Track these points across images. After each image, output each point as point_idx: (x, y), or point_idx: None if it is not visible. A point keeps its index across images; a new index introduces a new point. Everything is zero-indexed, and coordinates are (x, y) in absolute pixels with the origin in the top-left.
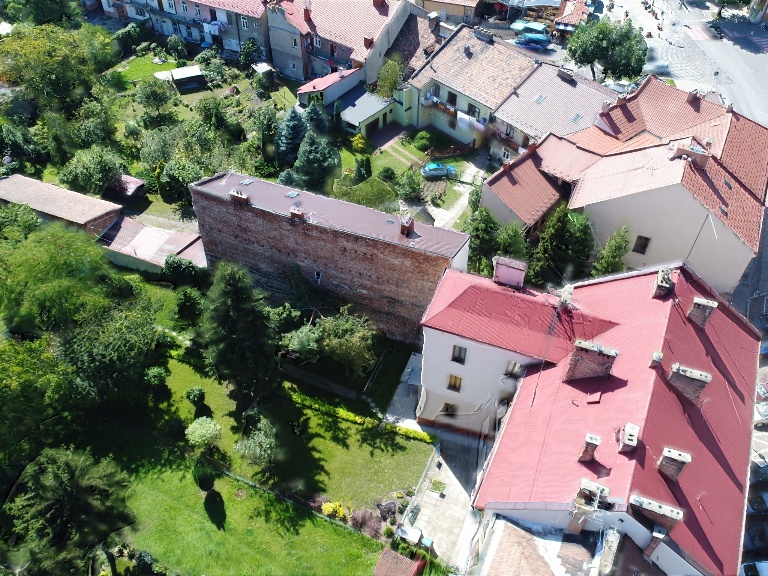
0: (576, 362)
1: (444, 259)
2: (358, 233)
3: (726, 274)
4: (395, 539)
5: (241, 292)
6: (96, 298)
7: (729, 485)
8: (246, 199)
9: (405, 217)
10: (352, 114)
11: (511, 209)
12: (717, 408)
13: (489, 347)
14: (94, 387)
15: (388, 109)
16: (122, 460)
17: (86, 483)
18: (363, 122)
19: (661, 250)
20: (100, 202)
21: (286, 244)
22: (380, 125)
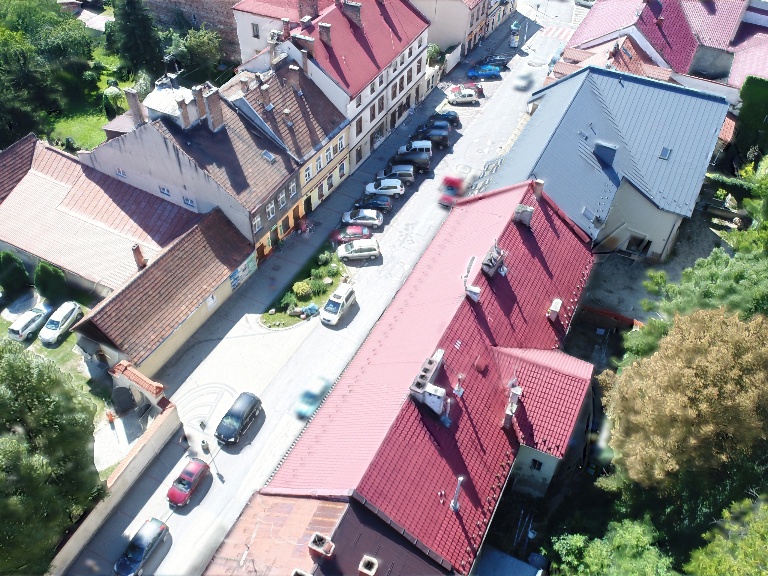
0: (301, 8)
1: None
2: None
3: (458, 28)
4: None
5: None
6: None
7: (370, 64)
8: None
9: None
10: None
11: None
12: (378, 36)
13: (267, 19)
14: (48, 62)
15: None
16: (64, 113)
17: (33, 69)
18: None
19: None
20: None
21: None
22: None
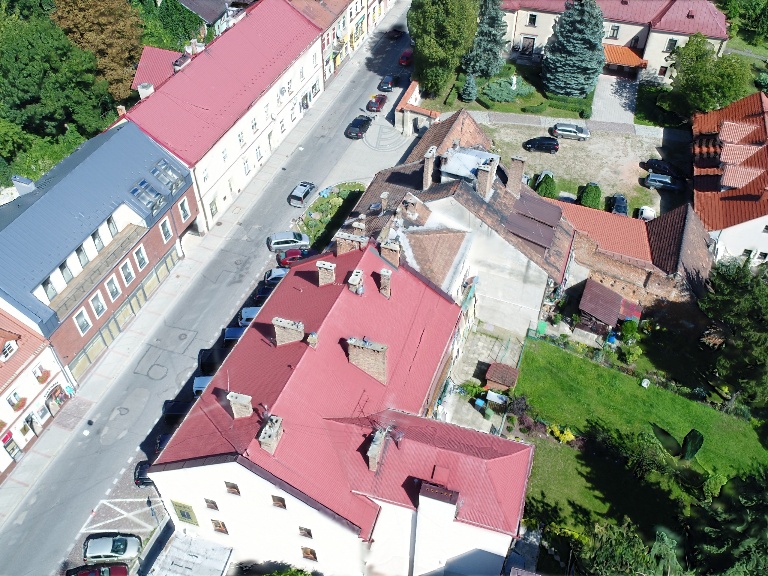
0: None
1: None
2: None
3: None
4: (507, 396)
5: None
6: None
7: None
8: None
9: None
10: None
11: None
12: None
13: None
14: None
15: None
16: None
17: (765, 335)
18: None
19: None
20: None
21: None
22: None
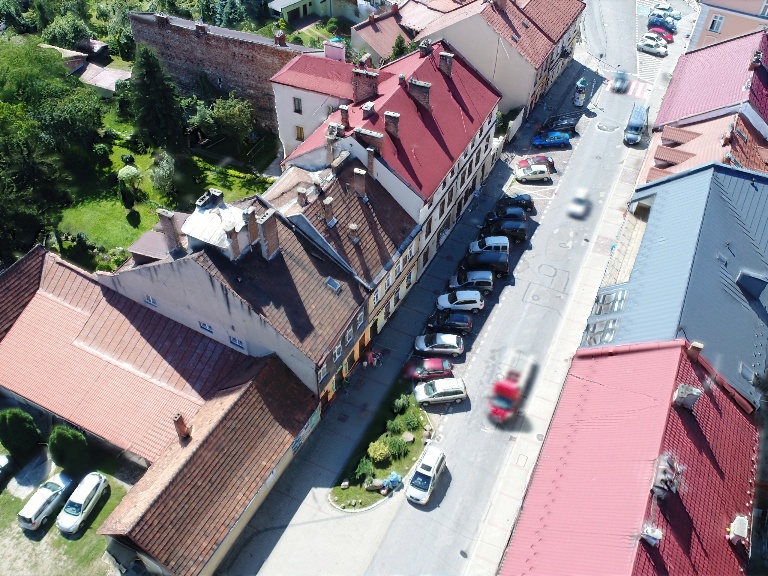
0: (356, 86)
1: (299, 54)
2: (241, 39)
3: (521, 89)
4: None
5: (153, 66)
6: (58, 84)
7: (443, 155)
8: (166, 18)
9: (277, 31)
10: (278, 4)
11: (371, 46)
12: (448, 119)
13: (313, 94)
14: (53, 139)
15: (307, 2)
16: None
17: (39, 160)
18: (285, 9)
19: None
20: (71, 52)
21: (196, 55)
22: (301, 15)
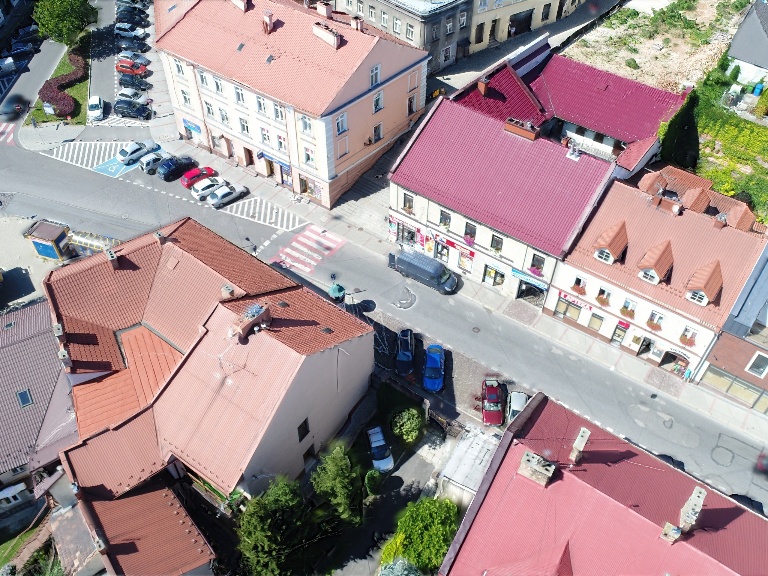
0: None
1: None
2: None
3: None
4: None
5: None
6: None
7: None
8: None
9: None
10: None
11: (183, 574)
12: (666, 488)
13: None
14: None
15: None
16: None
17: None
18: None
19: (319, 413)
20: None
21: None
22: None
